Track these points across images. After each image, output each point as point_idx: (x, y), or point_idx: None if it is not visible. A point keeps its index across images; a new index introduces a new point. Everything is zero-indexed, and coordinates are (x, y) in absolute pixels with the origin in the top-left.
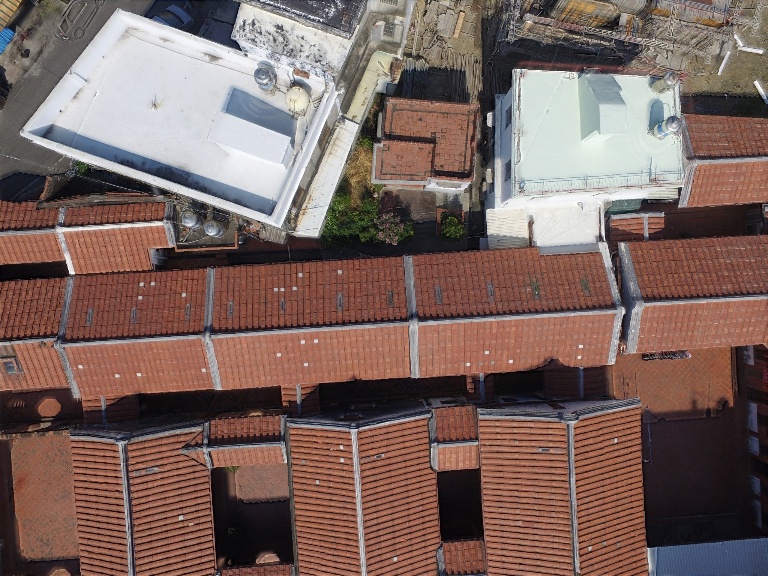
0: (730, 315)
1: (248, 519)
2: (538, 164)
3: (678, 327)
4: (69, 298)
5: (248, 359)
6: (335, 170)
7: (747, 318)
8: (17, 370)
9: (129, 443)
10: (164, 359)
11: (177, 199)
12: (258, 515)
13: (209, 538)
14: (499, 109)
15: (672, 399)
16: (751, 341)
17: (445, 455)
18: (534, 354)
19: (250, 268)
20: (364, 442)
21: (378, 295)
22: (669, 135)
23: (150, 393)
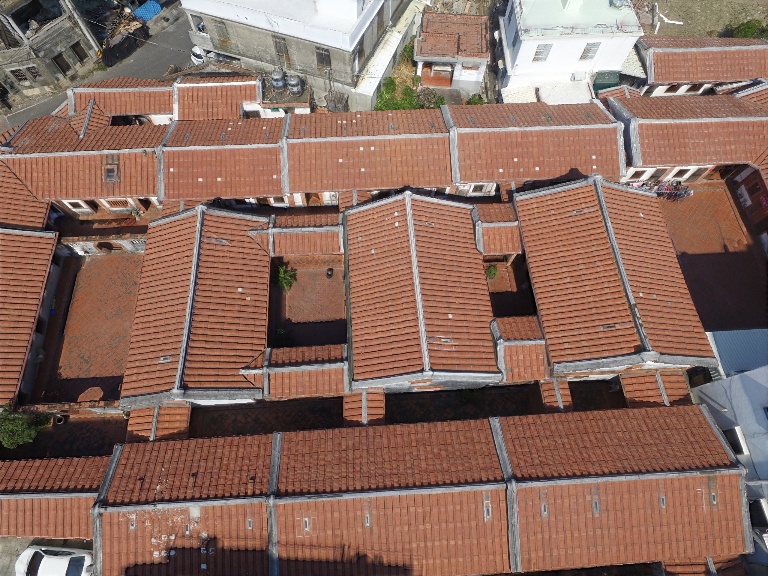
0: (711, 135)
1: (295, 338)
2: (536, 21)
3: (671, 143)
4: (172, 129)
5: (314, 163)
6: (386, 58)
7: (726, 137)
8: (116, 176)
9: (206, 213)
10: (243, 166)
11: (266, 76)
12: (305, 335)
13: (263, 316)
14: (503, 23)
15: (689, 237)
16: (737, 159)
17: (489, 236)
18: (556, 163)
19: (319, 114)
20: (416, 209)
21: (422, 123)
22: (625, 8)
23: (224, 199)
